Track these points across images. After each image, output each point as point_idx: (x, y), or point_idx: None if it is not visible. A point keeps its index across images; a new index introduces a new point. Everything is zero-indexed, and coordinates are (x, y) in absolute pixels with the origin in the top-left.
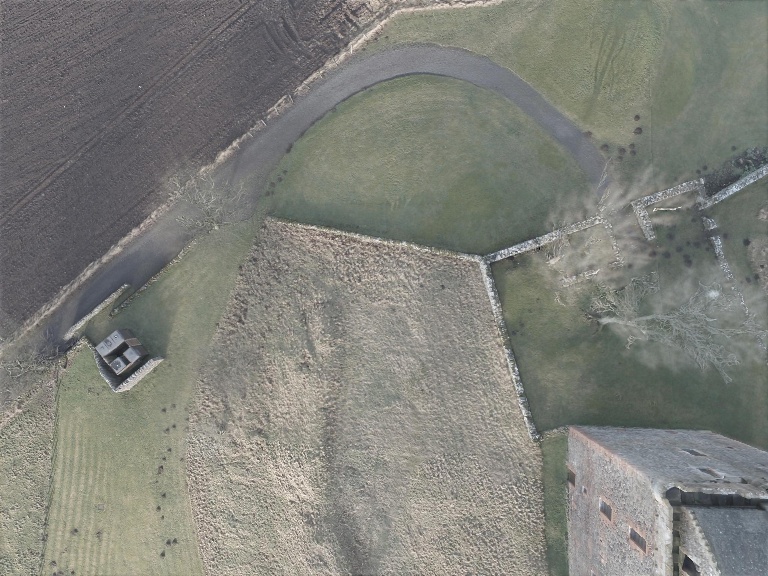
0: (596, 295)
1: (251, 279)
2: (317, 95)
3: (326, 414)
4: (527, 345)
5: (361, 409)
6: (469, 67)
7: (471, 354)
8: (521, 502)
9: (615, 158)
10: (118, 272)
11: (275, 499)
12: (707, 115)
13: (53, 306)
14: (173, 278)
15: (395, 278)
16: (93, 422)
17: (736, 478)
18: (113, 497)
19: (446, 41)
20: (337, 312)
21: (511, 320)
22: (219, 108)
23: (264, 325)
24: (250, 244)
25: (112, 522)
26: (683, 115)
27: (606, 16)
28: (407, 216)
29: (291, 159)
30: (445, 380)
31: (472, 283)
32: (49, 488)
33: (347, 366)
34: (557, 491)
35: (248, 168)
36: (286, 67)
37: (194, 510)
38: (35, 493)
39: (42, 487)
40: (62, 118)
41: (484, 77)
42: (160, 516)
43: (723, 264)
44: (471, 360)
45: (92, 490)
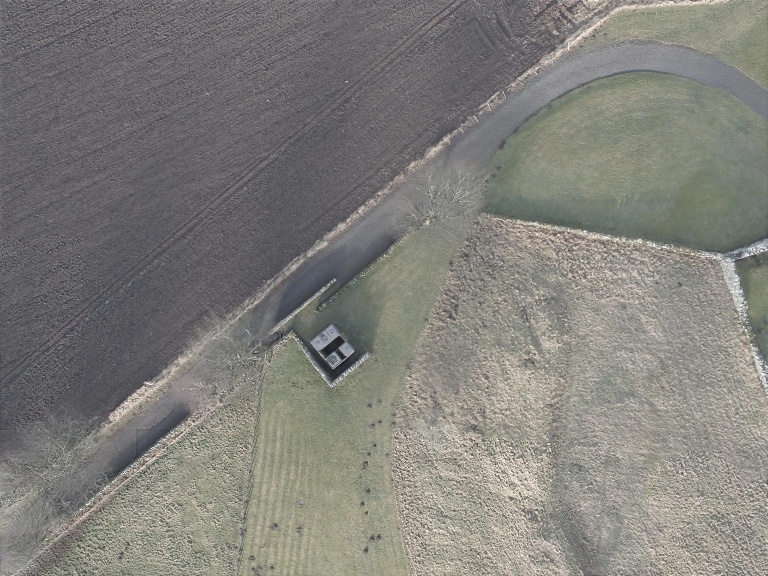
0: None
1: (462, 275)
2: (531, 91)
3: (552, 410)
4: None
5: (587, 406)
6: (693, 65)
7: (713, 352)
8: None
9: None
10: (323, 267)
11: (490, 495)
12: None
13: (257, 300)
14: (381, 273)
15: (626, 275)
16: (296, 417)
17: None
18: (315, 492)
19: (669, 39)
20: (562, 308)
21: (755, 318)
22: (429, 103)
23: (478, 321)
24: (461, 240)
25: (314, 517)
26: None
27: None
28: (635, 213)
29: (505, 155)
30: (687, 377)
31: (711, 281)
32: (248, 482)
33: (573, 363)
34: None
35: (459, 164)
36: (499, 63)
37: (399, 506)
38: (234, 487)
39: (241, 481)
40: (266, 112)
41: (709, 75)
42: (364, 511)
43: None
44: (714, 358)
45: (293, 485)
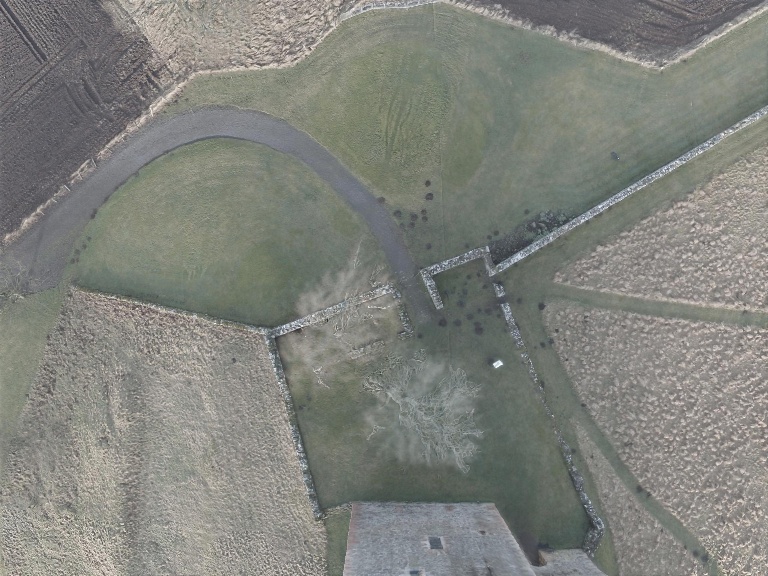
0: (385, 366)
1: (59, 349)
2: (120, 159)
3: (126, 490)
4: (313, 420)
5: (162, 483)
6: (267, 130)
7: (260, 430)
8: None
9: (407, 224)
10: None
11: (85, 574)
12: (499, 179)
13: None
14: None
15: (190, 351)
16: None
17: None
18: None
19: (244, 104)
20: (136, 385)
21: (298, 394)
22: (23, 173)
23: (71, 396)
24: (57, 313)
25: None
26: (475, 179)
27: (394, 80)
28: (203, 286)
29: (95, 225)
30: (234, 457)
31: (262, 356)
32: None
33: (147, 440)
34: (341, 569)
35: (53, 235)
36: (88, 130)
37: None
38: None
39: None
40: None
41: (282, 141)
42: None
43: (513, 331)
44: (260, 436)
45: None
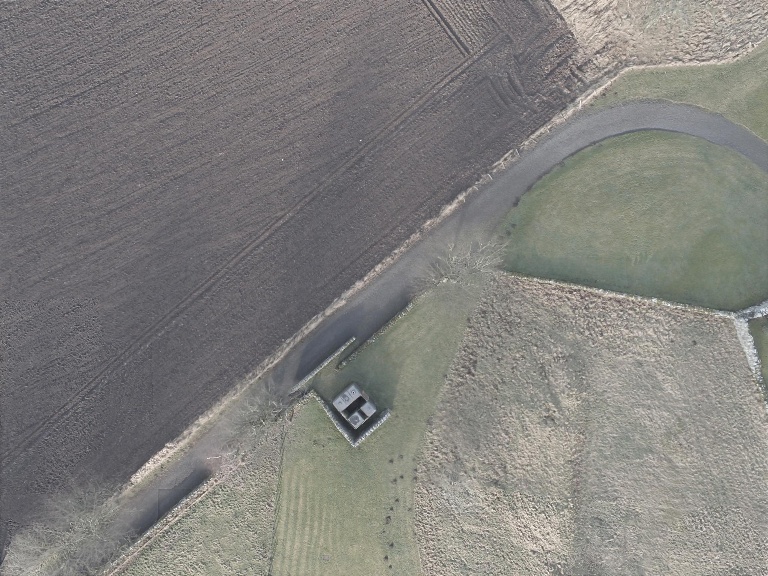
0: None
1: (480, 331)
2: (544, 149)
3: (573, 466)
4: None
5: (606, 461)
6: (702, 123)
7: (729, 409)
8: None
9: None
10: (341, 325)
11: (513, 549)
12: None
13: (276, 359)
14: (400, 331)
15: (642, 333)
16: (318, 474)
17: None
18: (339, 547)
19: (678, 98)
20: (580, 366)
21: None
22: (443, 162)
23: (496, 377)
24: (478, 297)
25: (338, 572)
26: None
27: None
28: (650, 271)
29: (519, 213)
30: (704, 434)
31: (725, 339)
32: (272, 539)
33: (591, 419)
34: None
35: (474, 221)
36: (512, 121)
37: (423, 559)
38: (257, 545)
39: (264, 539)
40: (280, 171)
41: (718, 133)
42: (387, 565)
43: None
44: (729, 415)
45: (317, 541)
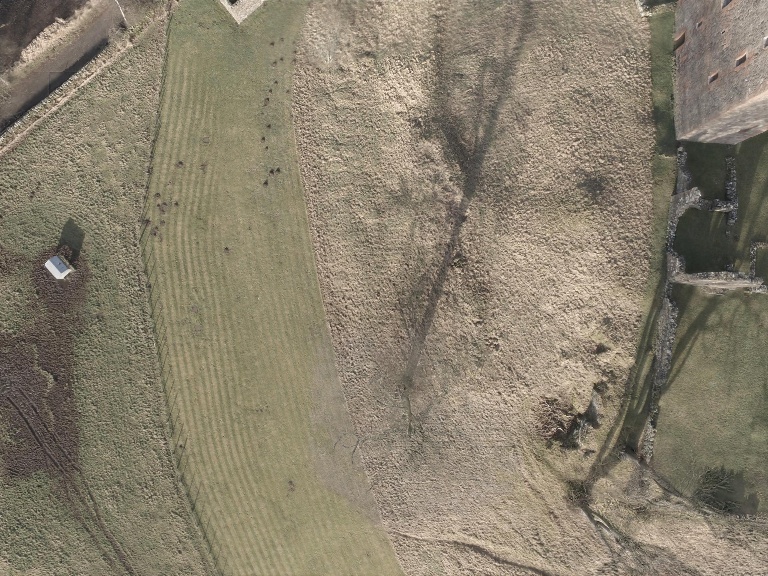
0: None
1: None
2: None
3: (437, 21)
4: None
5: (470, 19)
6: None
7: None
8: (629, 70)
9: None
10: None
11: (381, 116)
12: None
13: None
14: None
15: None
16: (202, 57)
17: None
18: (219, 130)
19: None
20: None
21: None
22: None
23: None
24: None
25: (217, 154)
26: None
27: None
28: None
29: None
30: None
31: None
32: (156, 123)
33: None
34: (663, 60)
35: None
36: None
37: (298, 140)
38: (142, 128)
39: (149, 122)
40: None
41: None
42: (264, 147)
43: None
44: None
45: (198, 123)
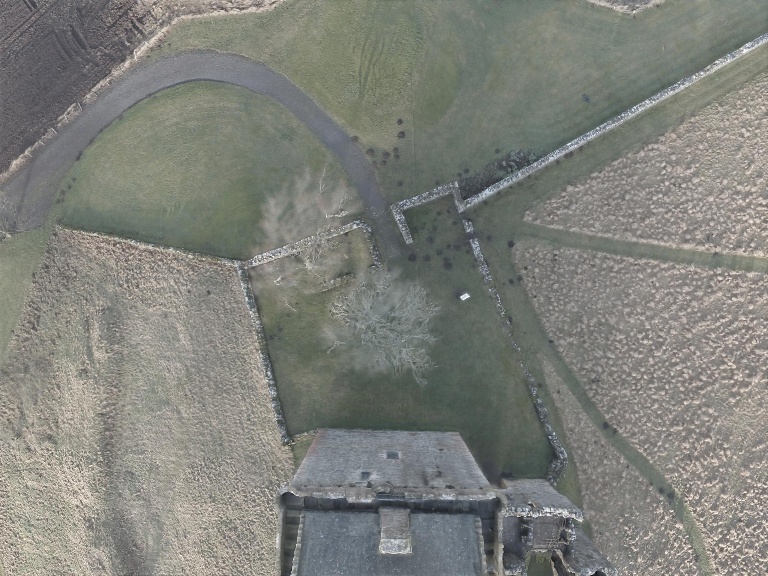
0: None
1: (43, 286)
2: (105, 102)
3: (104, 420)
4: (284, 349)
5: (139, 414)
6: (246, 73)
7: (232, 359)
8: (272, 505)
9: (379, 162)
10: None
11: (64, 504)
12: (470, 118)
13: None
14: None
15: (166, 284)
16: None
17: (365, 482)
18: None
19: (224, 47)
20: (115, 318)
21: (269, 325)
22: (12, 117)
23: (54, 332)
24: (42, 251)
25: None
26: (446, 118)
27: (368, 21)
28: (181, 222)
29: (80, 166)
30: (206, 385)
31: (235, 288)
32: None
33: (125, 372)
34: None
35: (40, 176)
36: (75, 75)
37: None
38: None
39: None
40: None
41: (260, 83)
42: None
43: (482, 266)
44: (231, 365)
45: None
